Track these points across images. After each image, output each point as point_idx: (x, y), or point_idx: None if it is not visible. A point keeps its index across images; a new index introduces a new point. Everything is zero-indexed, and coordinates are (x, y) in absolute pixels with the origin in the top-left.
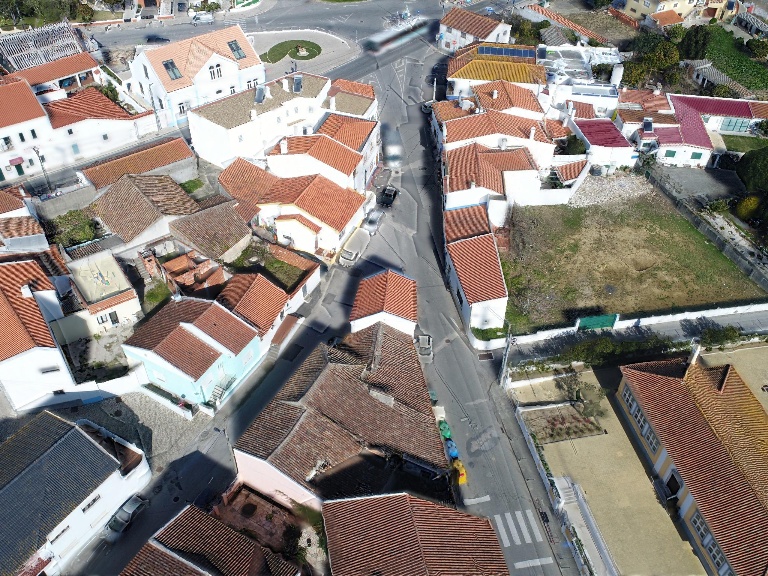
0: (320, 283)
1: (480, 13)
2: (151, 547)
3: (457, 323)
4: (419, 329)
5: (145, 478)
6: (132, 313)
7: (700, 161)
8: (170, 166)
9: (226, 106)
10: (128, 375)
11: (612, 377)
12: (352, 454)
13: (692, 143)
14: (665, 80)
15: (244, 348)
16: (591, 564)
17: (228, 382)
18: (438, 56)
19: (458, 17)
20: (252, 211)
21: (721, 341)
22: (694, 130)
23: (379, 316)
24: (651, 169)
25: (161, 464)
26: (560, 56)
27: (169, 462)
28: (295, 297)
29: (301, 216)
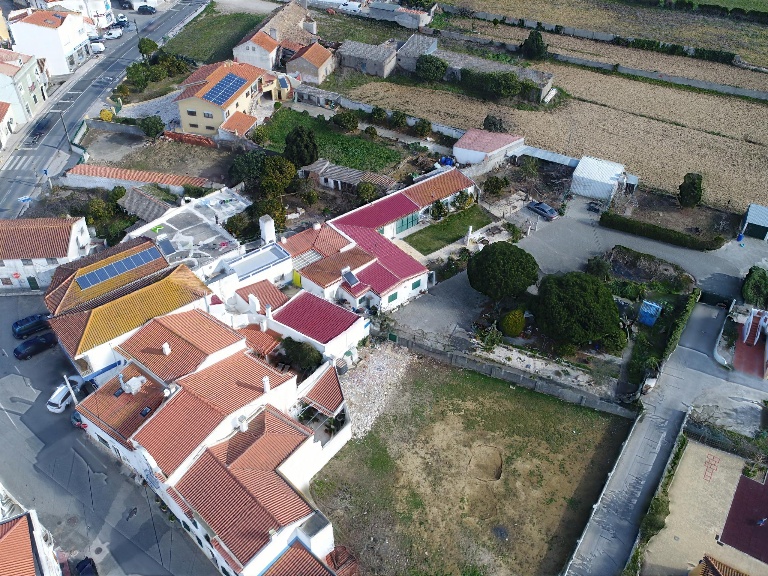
0: None
1: (7, 205)
2: None
3: None
4: None
5: None
6: None
7: (421, 287)
8: None
9: None
10: None
11: None
12: None
13: (407, 275)
14: (304, 203)
15: None
16: None
17: None
18: (1, 304)
19: (1, 240)
20: None
21: (662, 525)
22: (392, 256)
23: None
24: (395, 331)
25: None
26: (173, 229)
27: None
28: None
29: None
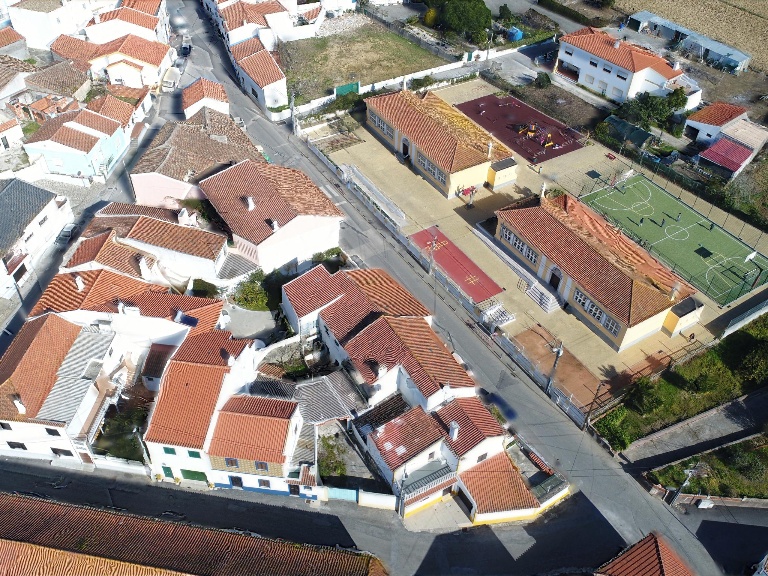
0: (153, 106)
1: None
2: (98, 218)
3: (257, 111)
4: (232, 117)
5: (71, 216)
6: (18, 139)
7: None
8: (7, 47)
9: (38, 1)
10: (35, 164)
11: (363, 117)
12: (209, 166)
13: None
14: None
15: (115, 132)
16: (367, 194)
17: (109, 158)
18: None
19: None
20: (86, 66)
21: (423, 83)
22: None
23: (203, 101)
24: (366, 7)
25: (78, 211)
26: None
27: (84, 209)
28: (138, 110)
29: (126, 60)
